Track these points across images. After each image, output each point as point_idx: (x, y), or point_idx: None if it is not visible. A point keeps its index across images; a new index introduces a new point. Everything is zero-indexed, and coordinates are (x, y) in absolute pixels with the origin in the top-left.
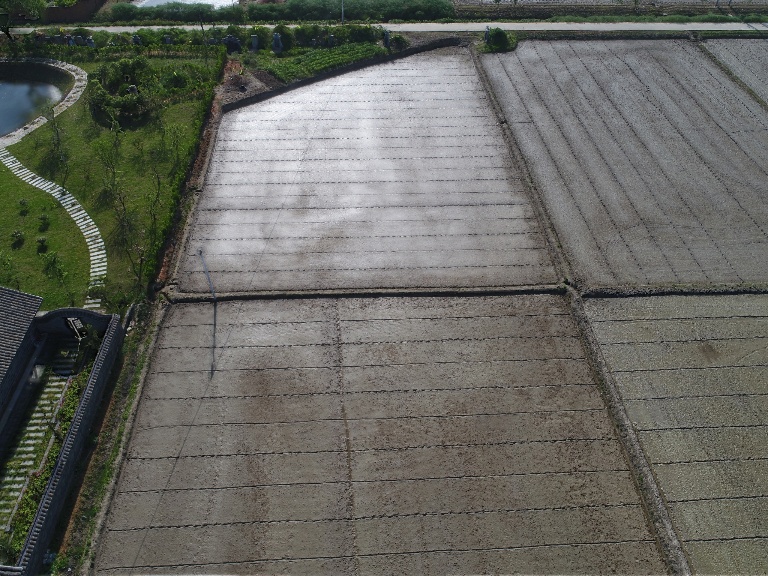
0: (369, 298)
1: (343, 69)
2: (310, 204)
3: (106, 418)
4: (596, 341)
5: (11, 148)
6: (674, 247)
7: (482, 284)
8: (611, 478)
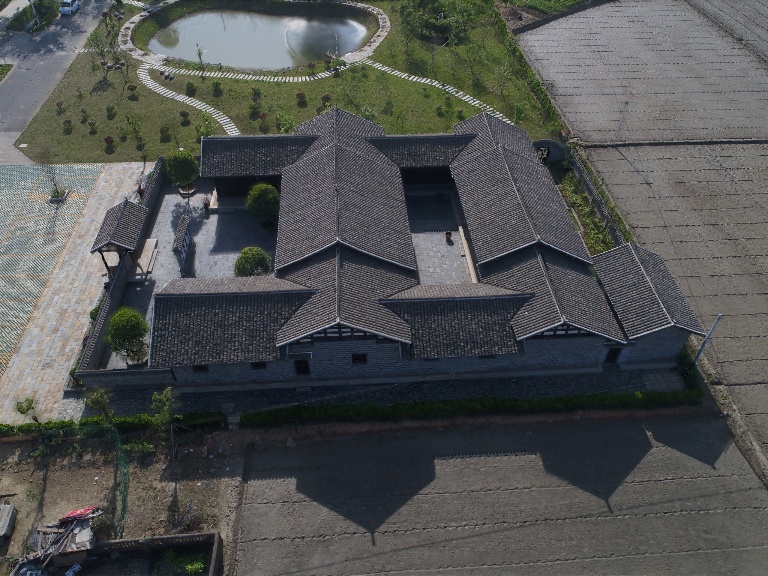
0: (725, 144)
1: (585, 6)
2: (634, 91)
3: None
4: None
5: (372, 58)
6: None
7: None
8: None
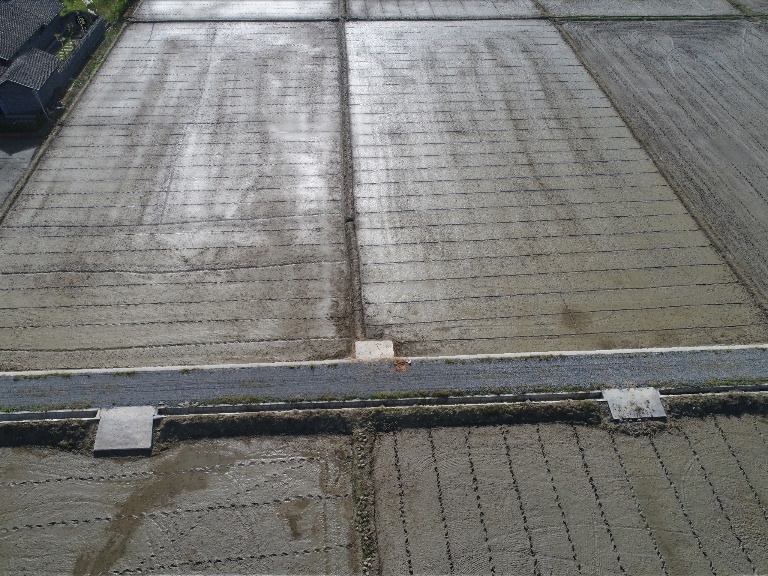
0: (235, 22)
1: None
2: None
3: (97, 51)
4: (344, 32)
5: None
6: (407, 7)
7: (296, 18)
8: (329, 66)
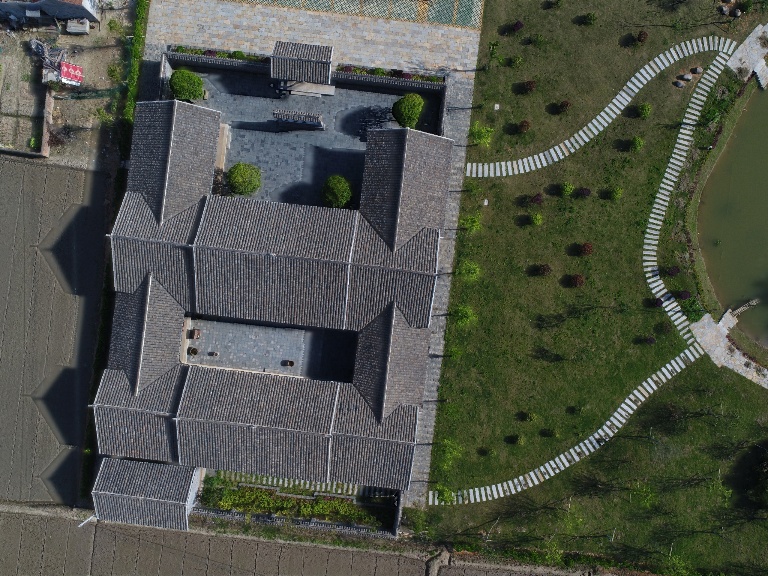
0: None
1: None
2: None
3: None
4: None
5: (702, 361)
6: None
7: None
8: None
